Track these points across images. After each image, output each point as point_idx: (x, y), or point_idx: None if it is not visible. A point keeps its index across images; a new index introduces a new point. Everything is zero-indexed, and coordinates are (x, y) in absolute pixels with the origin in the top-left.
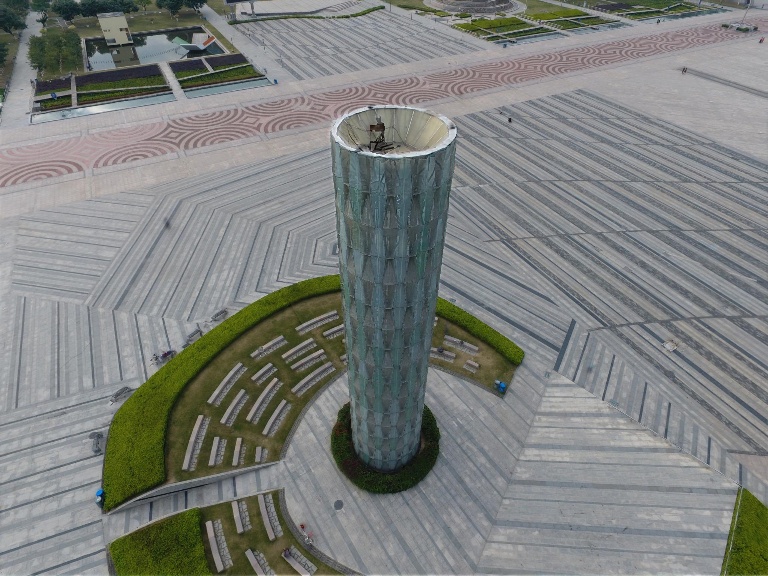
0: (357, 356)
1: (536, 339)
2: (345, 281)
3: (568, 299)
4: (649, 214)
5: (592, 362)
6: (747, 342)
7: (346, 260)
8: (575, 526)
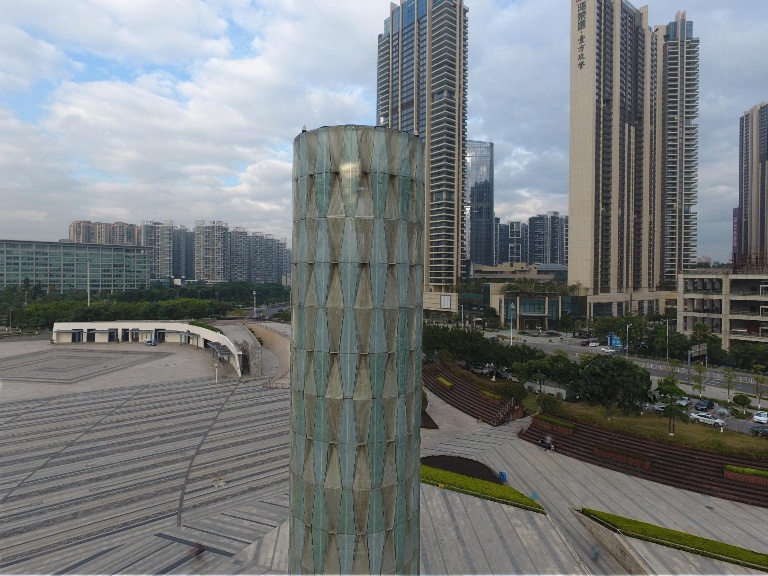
0: (411, 474)
1: (175, 568)
2: (397, 338)
3: (115, 535)
4: (8, 463)
5: (227, 528)
6: (226, 453)
7: (407, 291)
8: (422, 552)
